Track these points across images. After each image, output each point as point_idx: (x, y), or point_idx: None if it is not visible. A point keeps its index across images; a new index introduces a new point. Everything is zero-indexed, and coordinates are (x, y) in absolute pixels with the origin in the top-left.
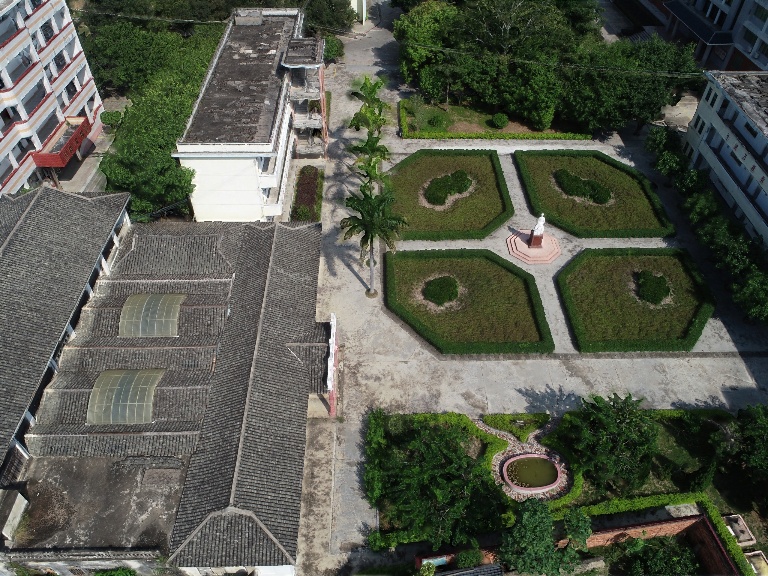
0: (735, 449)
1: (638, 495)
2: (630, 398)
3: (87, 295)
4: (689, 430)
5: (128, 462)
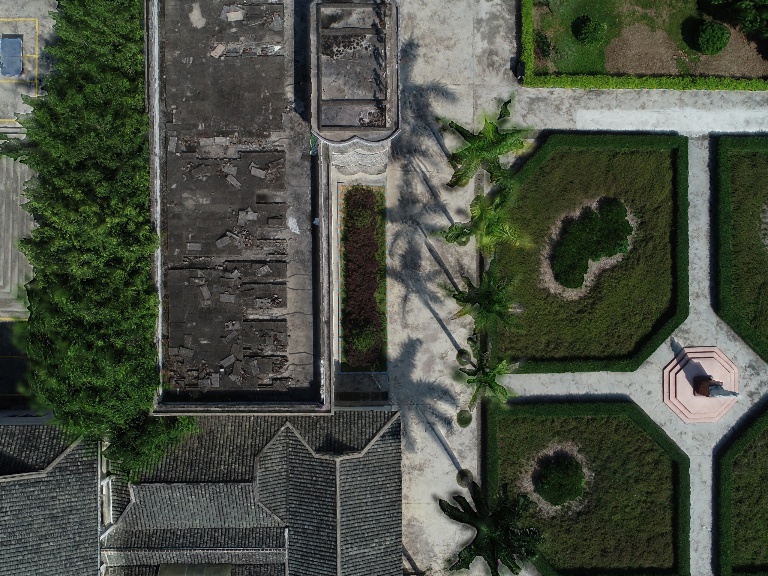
0: None
1: None
2: None
3: None
4: None
5: None
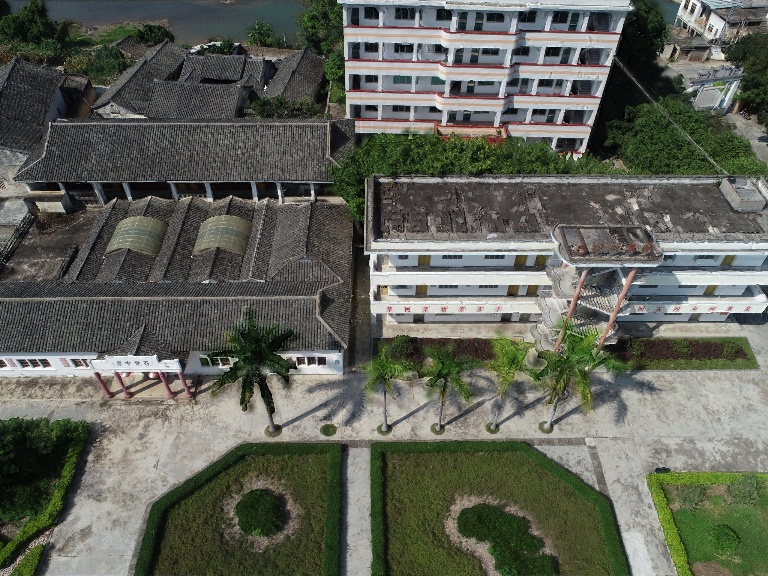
0: None
1: None
2: None
3: (251, 196)
4: None
5: None
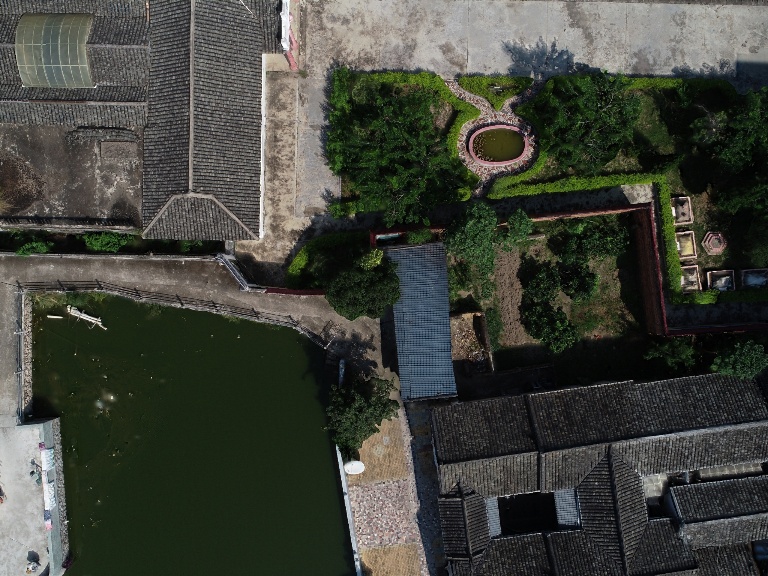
0: (713, 138)
1: (599, 172)
2: (620, 81)
3: None
4: (679, 104)
5: (80, 134)
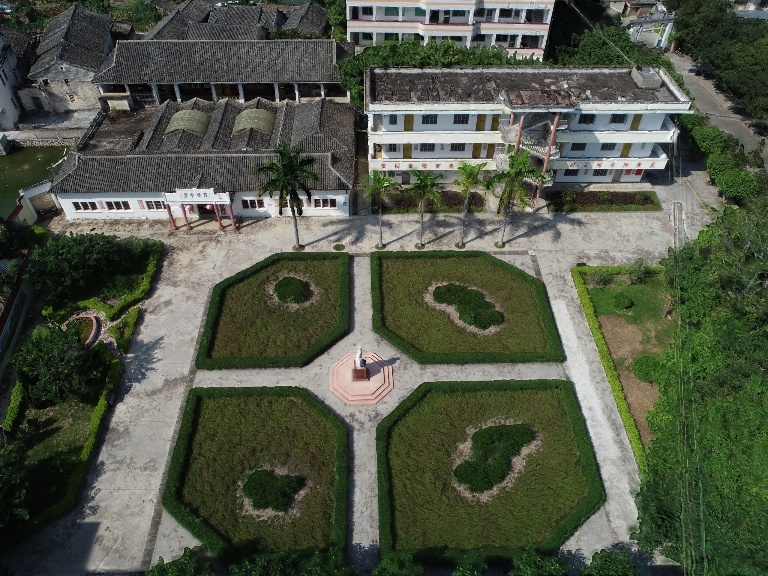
0: None
1: (28, 404)
2: (65, 356)
3: (274, 98)
4: None
5: None
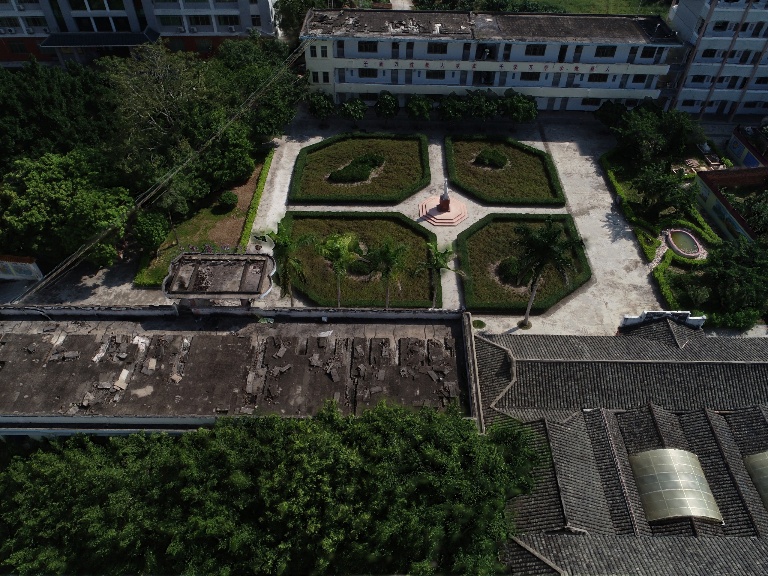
0: None
1: None
2: None
3: None
4: None
5: None
